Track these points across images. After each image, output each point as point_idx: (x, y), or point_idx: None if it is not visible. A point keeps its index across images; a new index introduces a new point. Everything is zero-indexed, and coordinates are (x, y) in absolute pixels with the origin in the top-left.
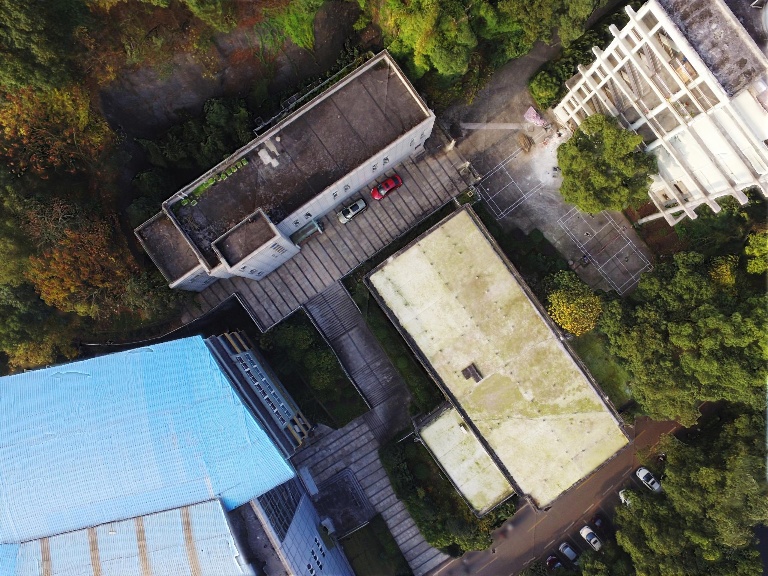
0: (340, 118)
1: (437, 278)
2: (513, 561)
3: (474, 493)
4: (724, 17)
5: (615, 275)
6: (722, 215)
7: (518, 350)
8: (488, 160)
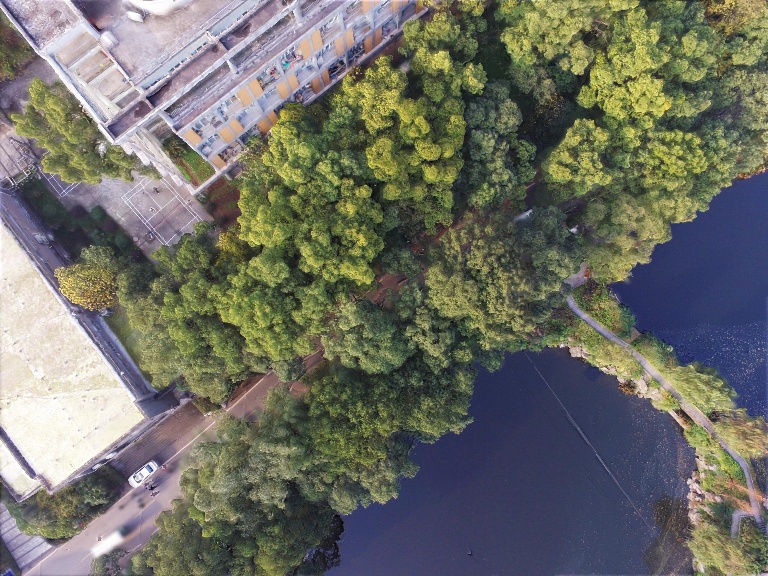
0: None
1: None
2: None
3: (15, 477)
4: None
5: None
6: None
7: (28, 327)
8: None
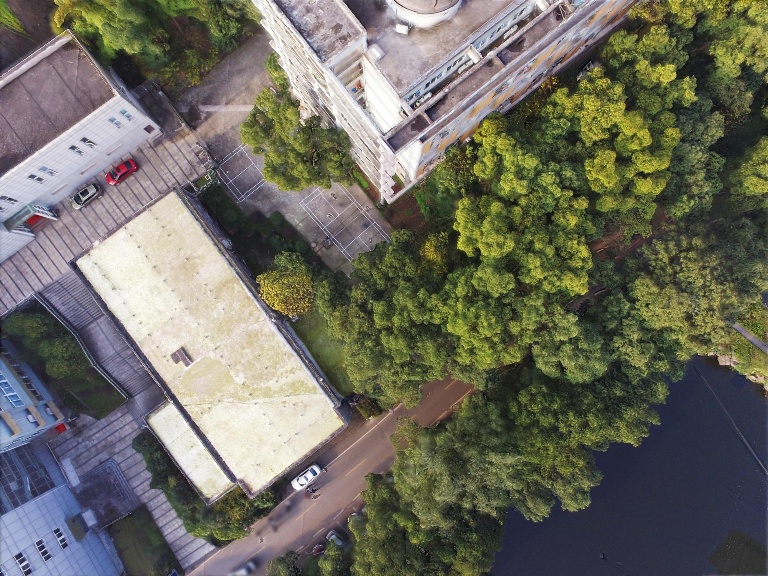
0: (29, 100)
1: (145, 261)
2: (280, 550)
3: (203, 480)
4: None
5: None
6: (454, 193)
7: (229, 333)
8: (227, 142)
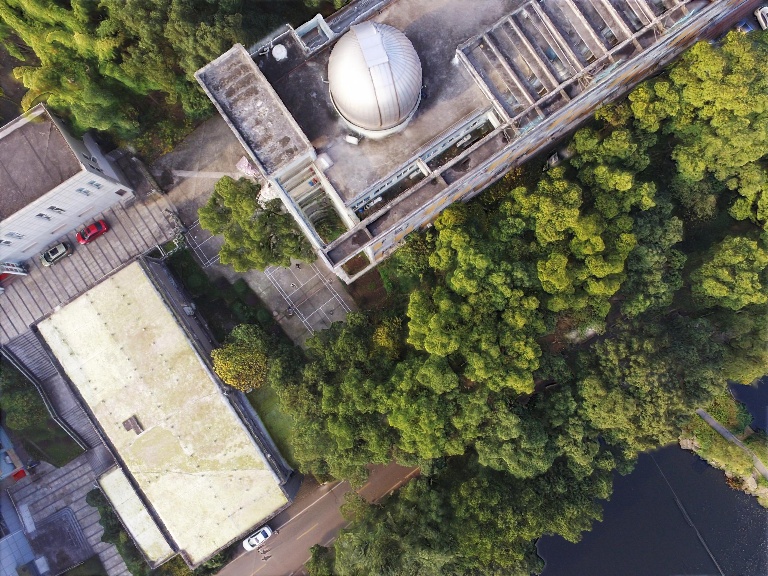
0: None
1: (103, 328)
2: None
3: (150, 543)
4: (270, 95)
5: (319, 328)
6: None
7: (181, 404)
8: (197, 208)
